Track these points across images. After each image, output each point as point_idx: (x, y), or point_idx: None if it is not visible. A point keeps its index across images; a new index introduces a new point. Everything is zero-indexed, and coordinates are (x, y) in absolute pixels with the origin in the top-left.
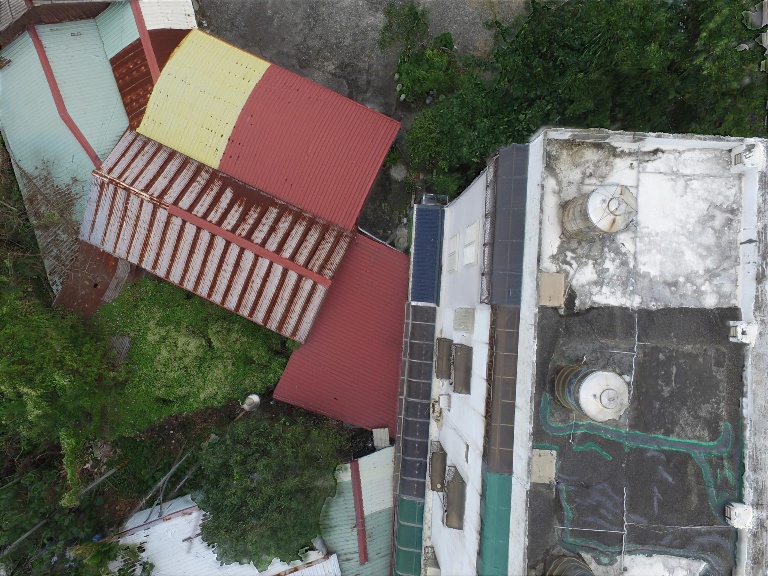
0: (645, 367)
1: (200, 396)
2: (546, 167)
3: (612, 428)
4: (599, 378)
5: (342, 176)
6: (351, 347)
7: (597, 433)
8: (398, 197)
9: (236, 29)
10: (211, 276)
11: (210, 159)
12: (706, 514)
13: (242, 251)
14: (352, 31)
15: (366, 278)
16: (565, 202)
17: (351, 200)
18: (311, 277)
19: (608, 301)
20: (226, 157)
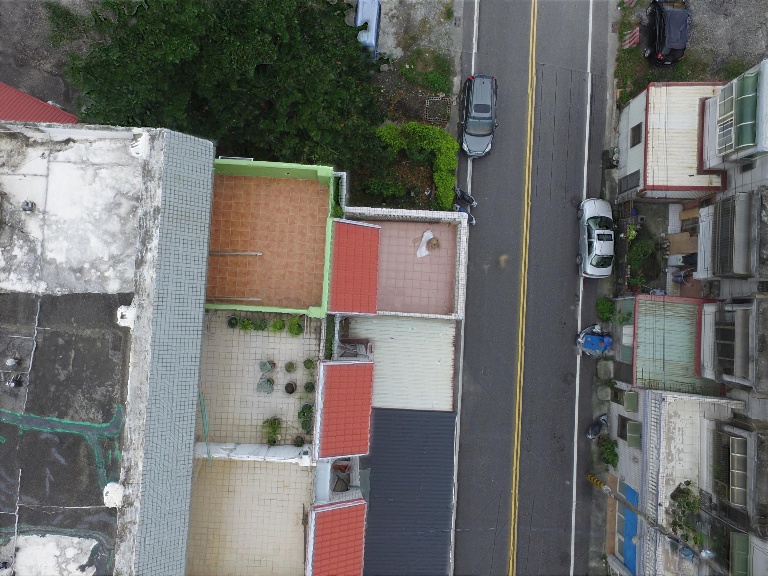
0: (43, 351)
1: None
2: None
3: (7, 411)
4: None
5: None
6: None
7: None
8: None
9: None
10: None
11: None
12: (96, 494)
13: None
14: (69, 30)
15: None
16: None
17: None
18: None
19: (14, 287)
20: None
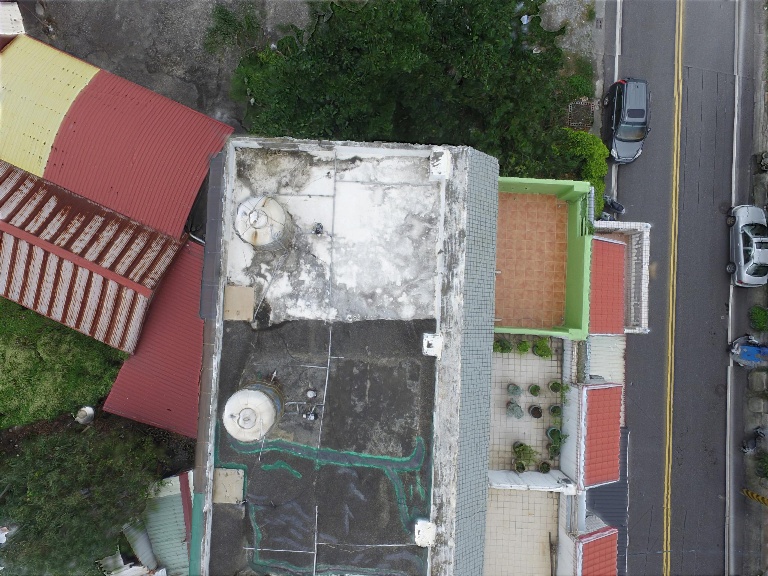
0: (338, 382)
1: (29, 409)
2: (240, 177)
3: (303, 445)
4: (241, 397)
5: (168, 183)
6: (185, 357)
7: (287, 450)
8: None
9: (83, 33)
10: (34, 287)
11: (34, 167)
12: (398, 532)
13: (61, 261)
14: (202, 35)
15: None
16: None
17: (178, 207)
18: (132, 287)
19: (303, 314)
20: (50, 165)
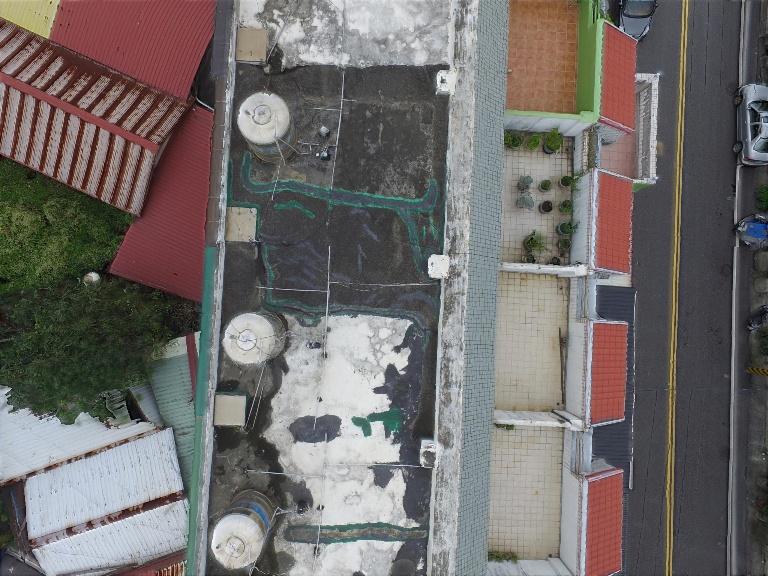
0: (351, 124)
1: (36, 273)
2: None
3: (315, 186)
4: (256, 97)
5: (175, 43)
6: (191, 222)
7: (300, 191)
8: None
9: None
10: (41, 146)
11: (40, 28)
12: (411, 272)
13: (68, 116)
14: None
15: (207, 152)
16: None
17: (185, 68)
18: (138, 142)
19: (316, 59)
20: (56, 25)
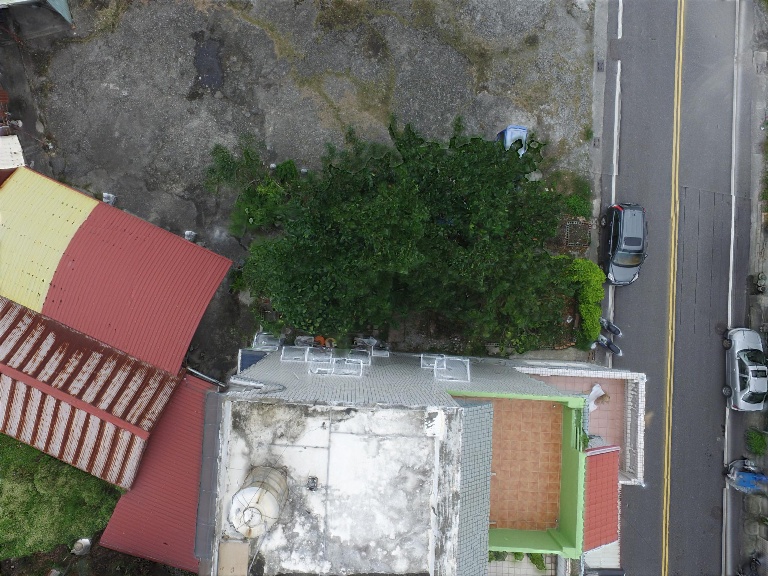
0: None
1: (26, 543)
2: (235, 428)
3: None
4: None
5: (166, 321)
6: (181, 490)
7: None
8: (247, 322)
9: (83, 151)
10: (32, 424)
11: (33, 303)
12: None
13: (59, 402)
14: (201, 152)
15: (197, 419)
16: (253, 466)
17: (176, 345)
18: (129, 429)
19: (297, 567)
20: (48, 301)
